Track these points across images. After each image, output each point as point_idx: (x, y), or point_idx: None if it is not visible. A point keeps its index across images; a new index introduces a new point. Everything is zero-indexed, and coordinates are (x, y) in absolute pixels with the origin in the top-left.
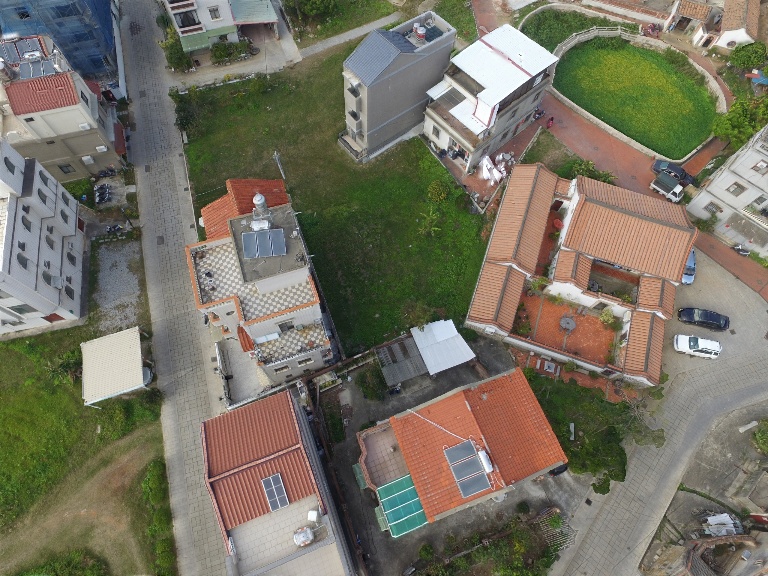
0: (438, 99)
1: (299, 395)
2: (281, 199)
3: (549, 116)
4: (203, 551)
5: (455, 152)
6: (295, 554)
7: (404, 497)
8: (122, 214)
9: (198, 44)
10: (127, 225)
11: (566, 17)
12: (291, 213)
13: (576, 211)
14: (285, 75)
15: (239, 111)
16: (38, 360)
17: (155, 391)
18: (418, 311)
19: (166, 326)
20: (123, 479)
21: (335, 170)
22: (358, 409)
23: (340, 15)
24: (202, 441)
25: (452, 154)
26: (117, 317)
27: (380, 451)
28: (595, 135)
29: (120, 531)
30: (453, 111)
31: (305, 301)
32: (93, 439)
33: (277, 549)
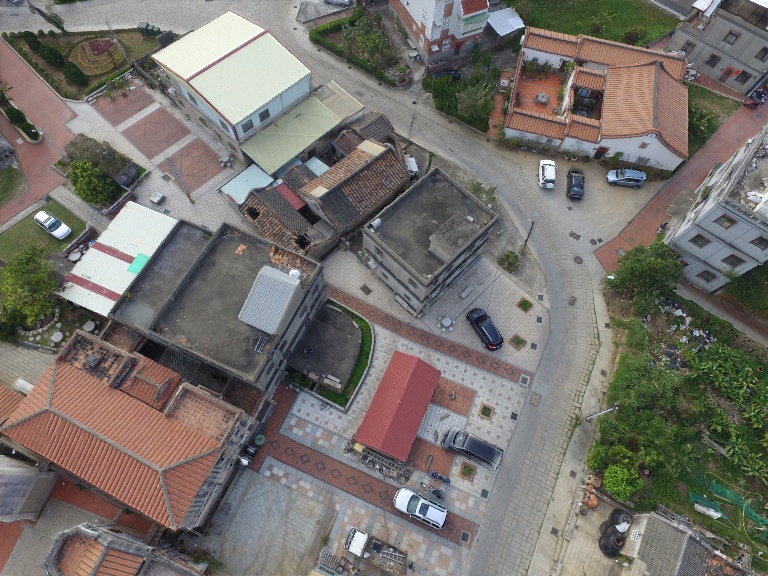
0: None
1: None
2: None
3: (761, 108)
4: None
5: None
6: None
7: None
8: None
9: None
10: None
11: None
12: None
13: None
14: None
15: None
16: None
17: None
18: None
19: None
20: None
21: None
22: None
23: None
24: None
25: None
26: None
27: None
28: None
29: None
30: None
31: None
32: None
33: None
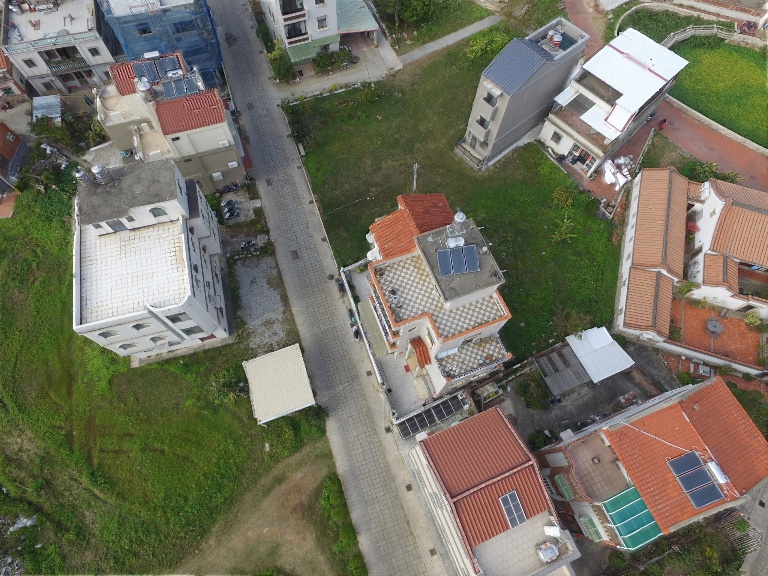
0: (567, 105)
1: (462, 407)
2: (448, 213)
3: (659, 118)
4: (392, 566)
5: (576, 157)
6: (545, 570)
7: (633, 509)
8: (253, 229)
9: (305, 54)
10: (259, 240)
11: (659, 17)
12: (475, 228)
13: (722, 215)
14: (389, 83)
15: (350, 121)
16: (195, 380)
17: (318, 407)
18: (576, 320)
19: (316, 341)
20: (300, 496)
21: (456, 178)
22: (522, 419)
23: (435, 20)
24: (428, 460)
25: (571, 159)
26: (266, 334)
27: (582, 463)
28: (708, 136)
29: (307, 548)
30: (584, 117)
31: (492, 316)
32: (263, 457)
33: (520, 565)
